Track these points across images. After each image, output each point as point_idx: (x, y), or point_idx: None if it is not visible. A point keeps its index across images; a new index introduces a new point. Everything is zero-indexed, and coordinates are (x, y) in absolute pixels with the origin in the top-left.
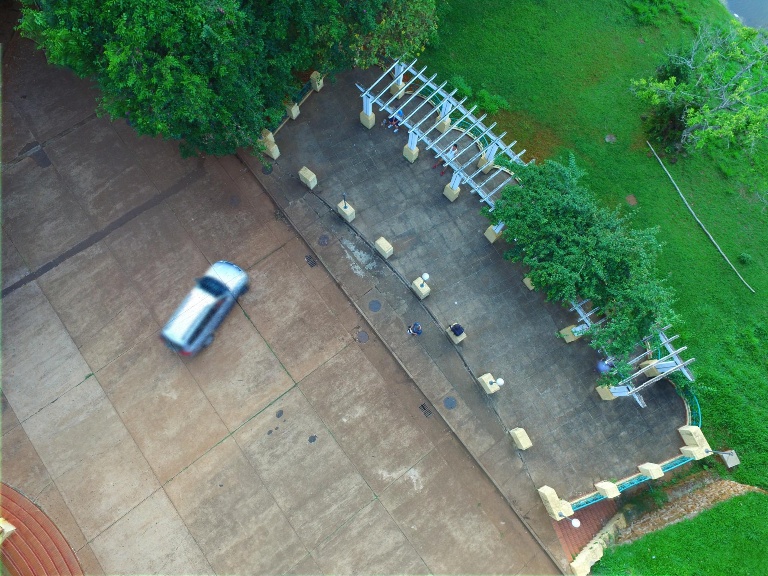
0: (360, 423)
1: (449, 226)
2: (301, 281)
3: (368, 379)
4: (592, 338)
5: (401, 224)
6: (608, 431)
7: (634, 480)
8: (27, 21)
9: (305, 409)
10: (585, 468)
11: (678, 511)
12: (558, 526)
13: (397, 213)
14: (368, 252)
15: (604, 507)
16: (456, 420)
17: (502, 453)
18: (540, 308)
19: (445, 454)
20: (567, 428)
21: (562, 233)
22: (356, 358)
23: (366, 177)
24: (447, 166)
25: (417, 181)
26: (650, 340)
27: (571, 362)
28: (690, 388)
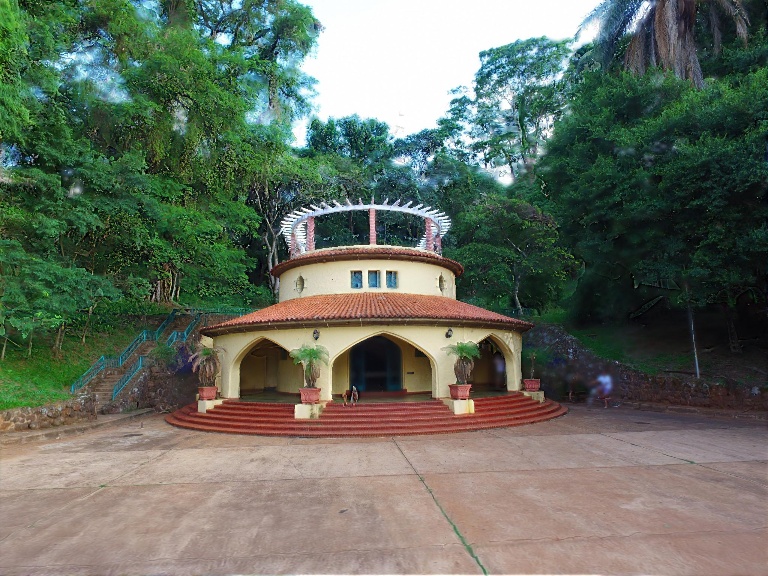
0: None
1: None
2: None
3: None
4: None
5: None
6: None
7: None
8: None
9: None
10: None
11: None
12: None
13: None
14: None
15: None
16: None
17: None
18: None
19: None
20: None
21: None
22: None
23: None
24: None
25: None
26: None
27: None
28: None
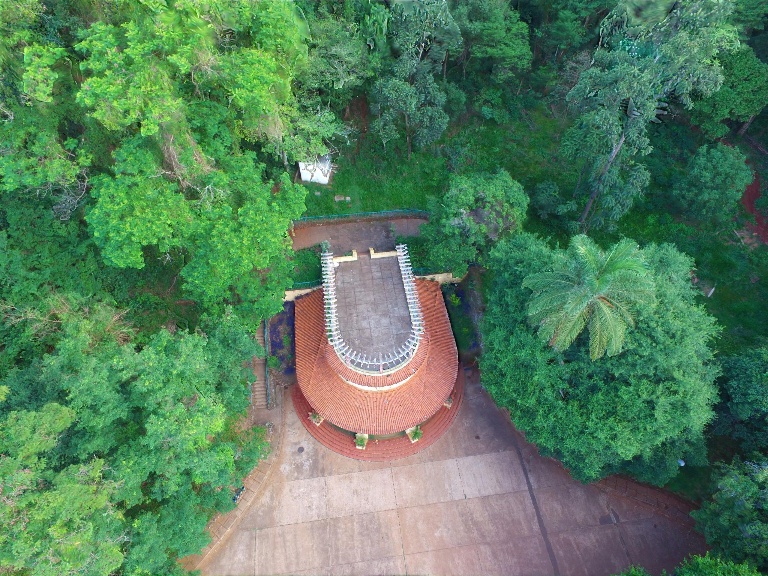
0: None
1: None
2: None
3: None
4: None
5: None
6: None
7: None
8: (635, 574)
9: None
10: None
11: None
12: None
13: None
14: None
15: None
16: None
17: None
18: None
19: None
20: None
21: None
22: None
23: None
24: None
25: None
26: None
27: None
28: None
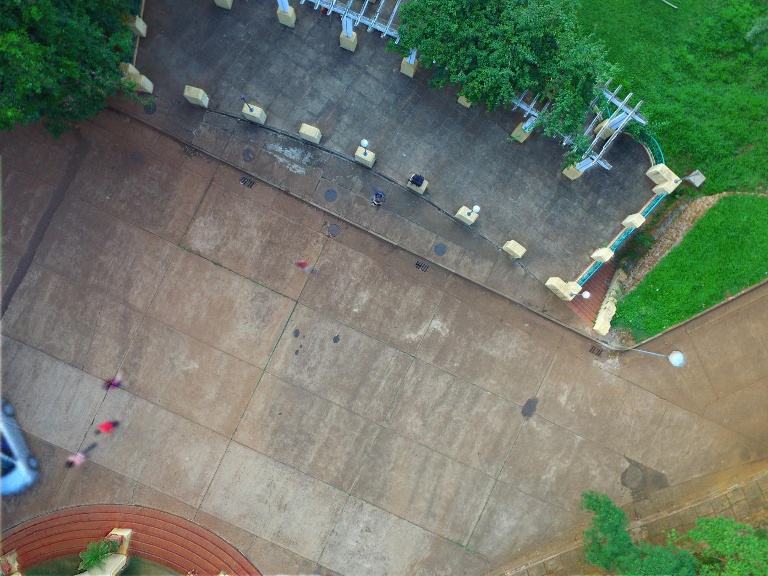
0: (370, 306)
1: (363, 80)
2: (249, 206)
3: (358, 265)
4: (544, 127)
5: (315, 101)
6: (586, 206)
7: (622, 236)
8: None
9: (316, 318)
10: (578, 247)
11: (666, 244)
12: (572, 305)
13: (305, 91)
14: (297, 146)
15: (604, 271)
16: (452, 262)
17: (503, 270)
18: (484, 121)
19: (455, 295)
20: (550, 221)
21: (477, 32)
22: (338, 252)
23: (254, 67)
24: (331, 13)
25: (308, 46)
26: (597, 102)
27: (532, 159)
28: (645, 131)
